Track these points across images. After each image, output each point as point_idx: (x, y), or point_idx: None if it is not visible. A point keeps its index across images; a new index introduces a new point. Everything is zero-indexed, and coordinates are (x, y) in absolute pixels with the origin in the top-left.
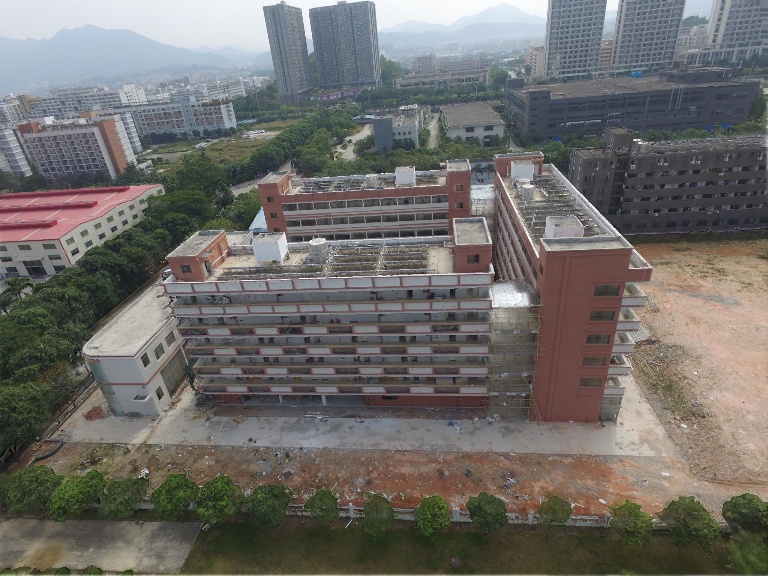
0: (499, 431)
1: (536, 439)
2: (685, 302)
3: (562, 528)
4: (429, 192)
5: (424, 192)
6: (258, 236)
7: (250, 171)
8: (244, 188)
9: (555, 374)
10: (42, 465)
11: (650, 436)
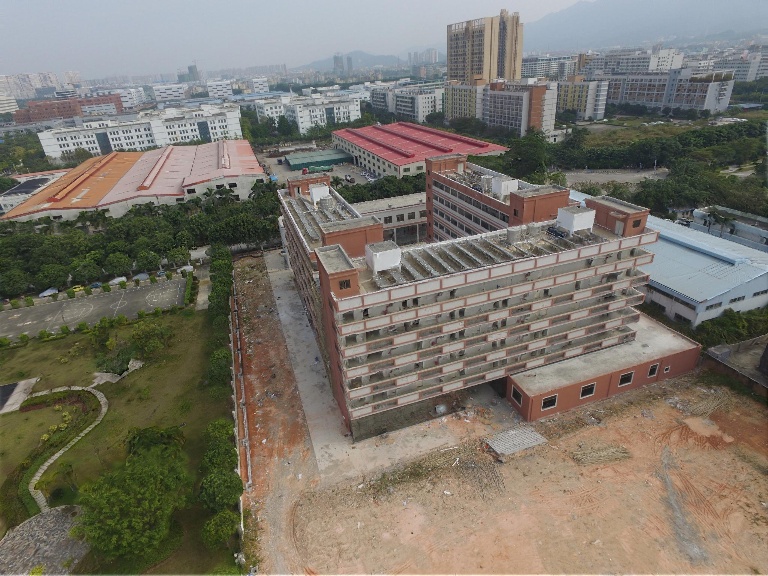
0: (319, 382)
1: (316, 401)
2: (634, 492)
3: (232, 419)
4: (498, 207)
5: (496, 205)
6: (320, 183)
7: (619, 159)
8: (597, 174)
9: (333, 362)
10: (229, 251)
11: (343, 466)
